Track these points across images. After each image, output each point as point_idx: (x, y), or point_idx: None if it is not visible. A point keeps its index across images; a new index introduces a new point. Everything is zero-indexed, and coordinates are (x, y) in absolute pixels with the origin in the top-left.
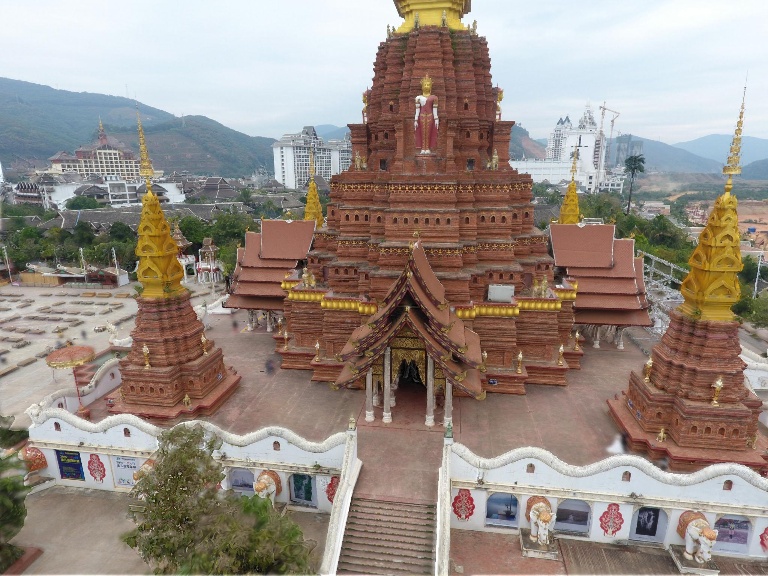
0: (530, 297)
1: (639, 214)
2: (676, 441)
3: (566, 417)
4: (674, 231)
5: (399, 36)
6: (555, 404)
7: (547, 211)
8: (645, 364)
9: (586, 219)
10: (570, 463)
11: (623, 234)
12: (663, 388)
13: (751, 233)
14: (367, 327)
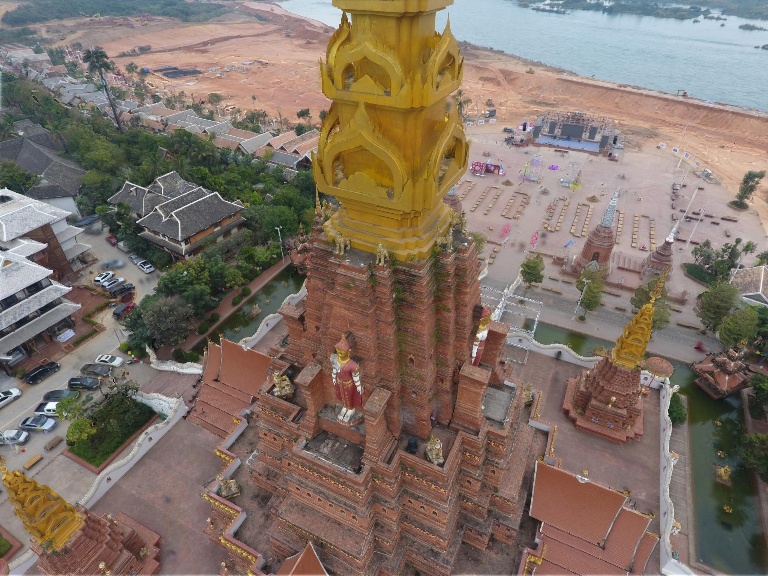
0: (534, 407)
1: (41, 82)
2: (631, 425)
3: (583, 456)
4: (211, 148)
5: (425, 265)
6: (565, 452)
7: (56, 165)
8: (581, 391)
9: (160, 178)
10: (639, 486)
11: (193, 177)
12: (624, 407)
13: (184, 92)
14: (586, 569)
